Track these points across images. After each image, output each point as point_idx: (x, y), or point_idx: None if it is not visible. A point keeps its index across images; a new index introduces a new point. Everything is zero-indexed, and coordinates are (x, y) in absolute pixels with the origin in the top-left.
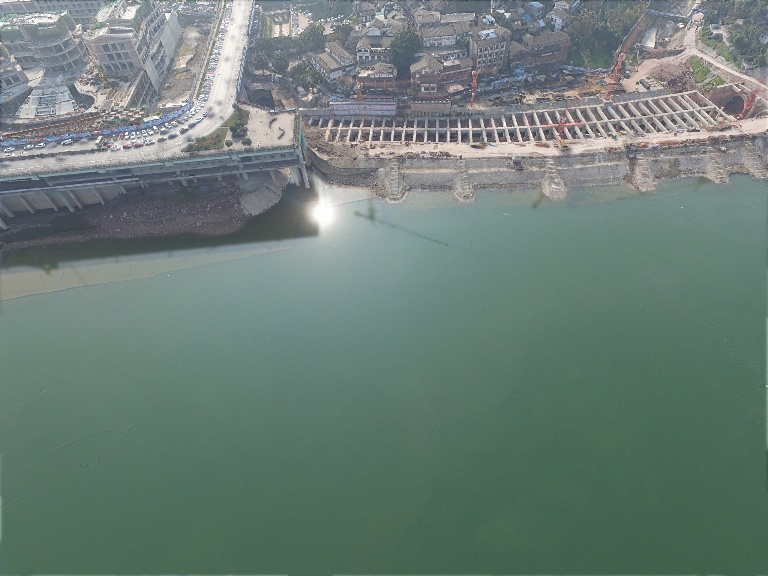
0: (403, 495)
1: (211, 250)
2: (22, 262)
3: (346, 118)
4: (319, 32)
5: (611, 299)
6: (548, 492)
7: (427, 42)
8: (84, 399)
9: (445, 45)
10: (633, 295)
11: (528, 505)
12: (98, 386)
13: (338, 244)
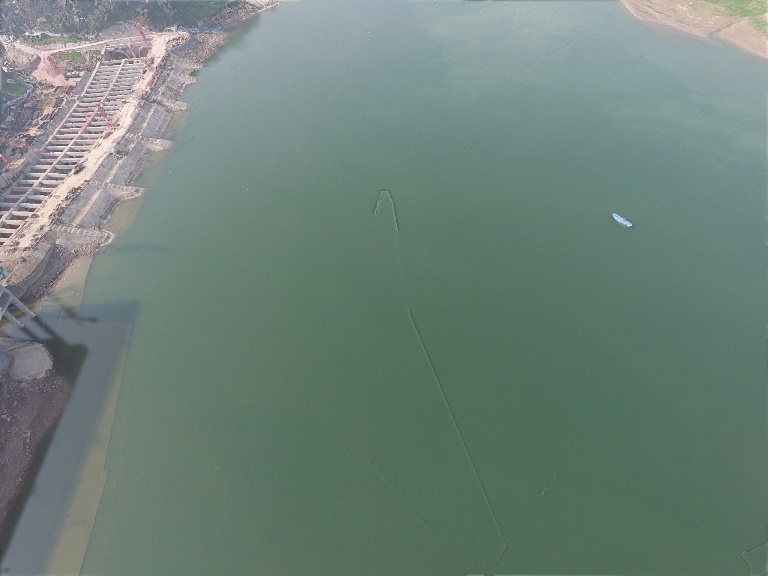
0: None
1: (91, 408)
2: None
3: None
4: None
5: (275, 136)
6: (394, 176)
7: None
8: (357, 274)
9: None
10: (275, 128)
11: (401, 184)
12: (351, 255)
13: (148, 281)
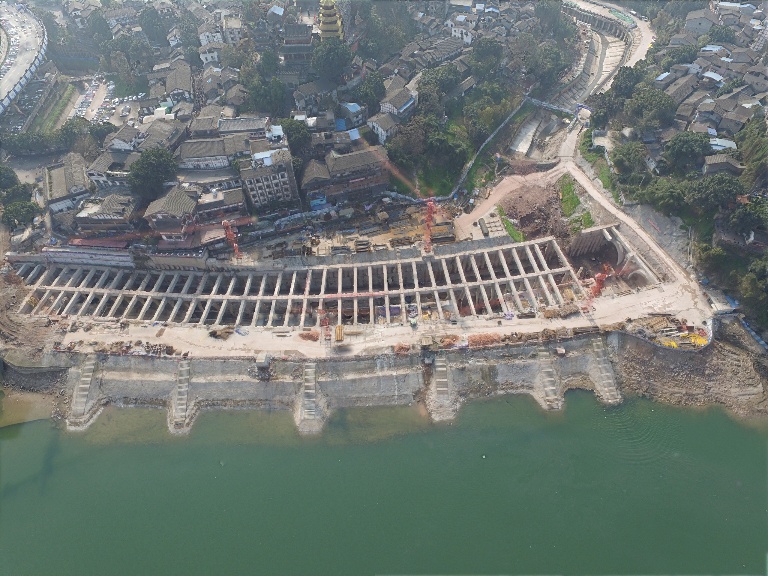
0: None
1: None
2: None
3: (72, 267)
4: (73, 131)
5: None
6: None
7: (188, 163)
8: None
9: (215, 166)
10: None
11: None
12: None
13: None
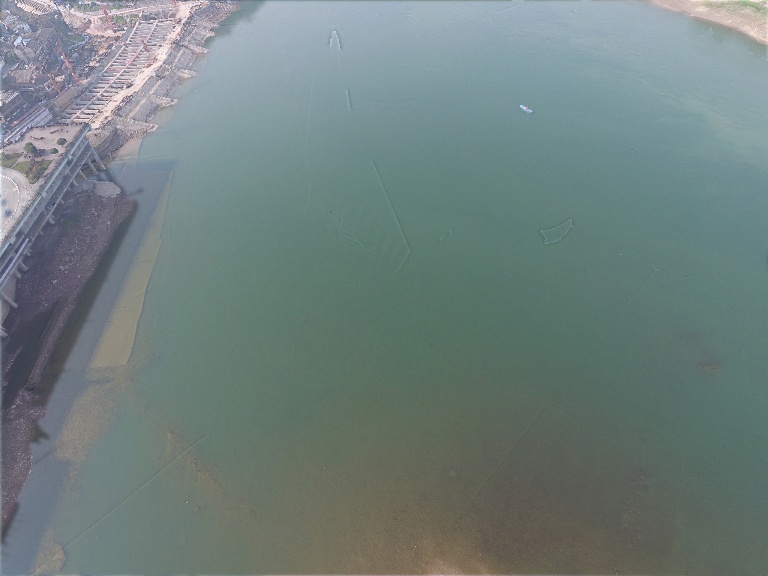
0: (362, 116)
1: (149, 212)
2: (75, 354)
3: None
4: None
5: (276, 67)
6: (365, 88)
7: None
8: (320, 92)
9: (1, 68)
10: (276, 62)
11: (369, 93)
12: (317, 81)
13: (183, 149)
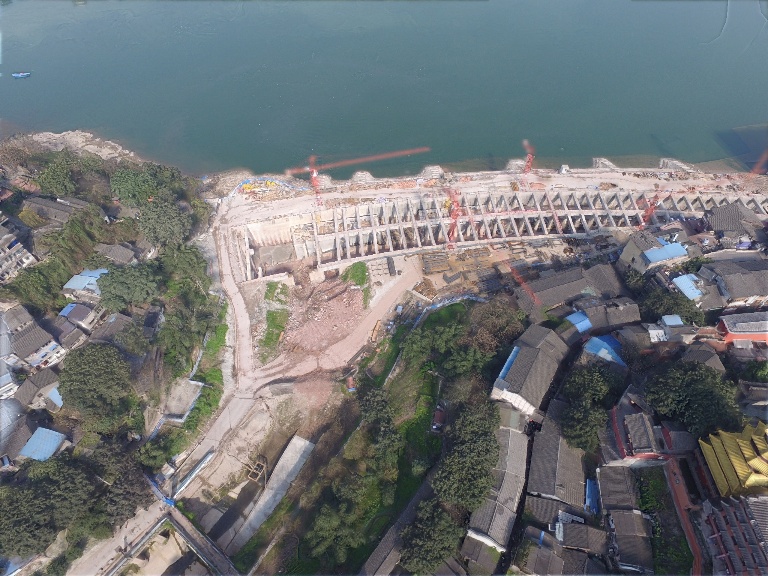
0: None
1: None
2: None
3: None
4: None
5: (487, 100)
6: None
7: None
8: None
9: None
10: (473, 102)
11: None
12: None
13: (695, 130)
